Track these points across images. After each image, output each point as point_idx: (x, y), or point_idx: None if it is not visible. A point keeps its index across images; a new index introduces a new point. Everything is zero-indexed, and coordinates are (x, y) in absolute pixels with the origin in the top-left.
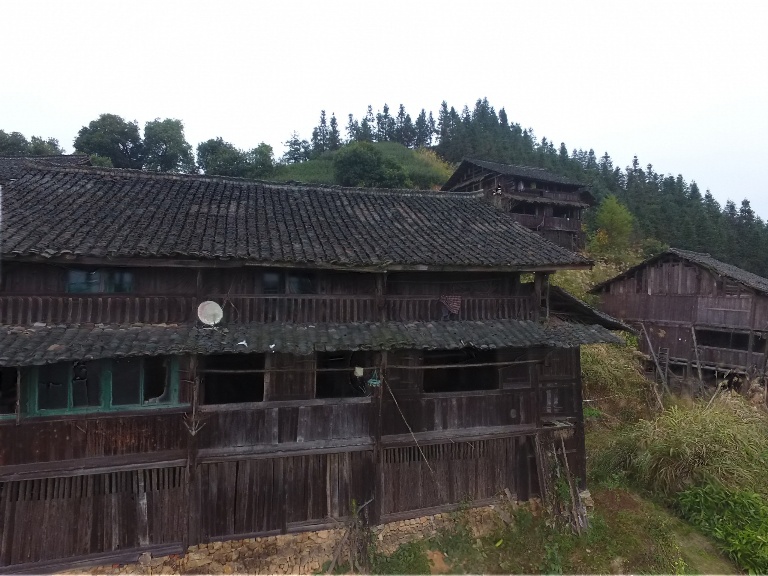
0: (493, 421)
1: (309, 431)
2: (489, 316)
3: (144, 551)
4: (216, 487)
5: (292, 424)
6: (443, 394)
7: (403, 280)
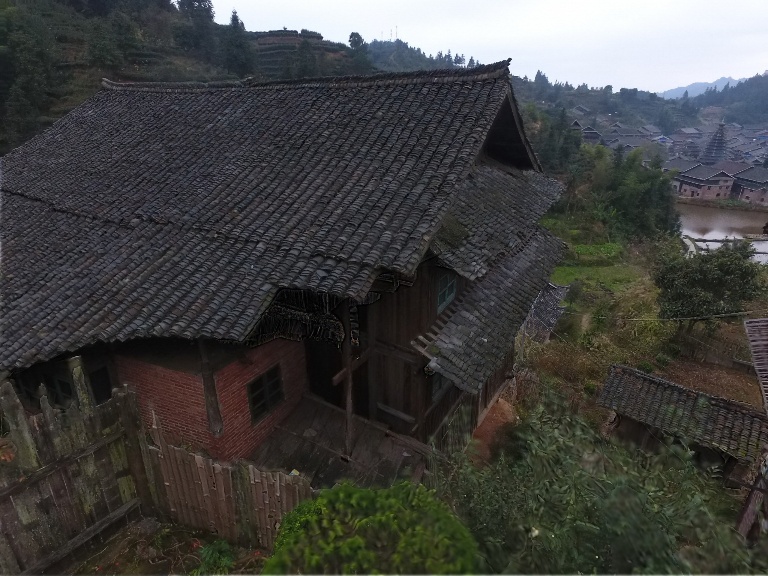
0: None
1: None
2: None
3: None
4: None
5: None
6: None
7: None
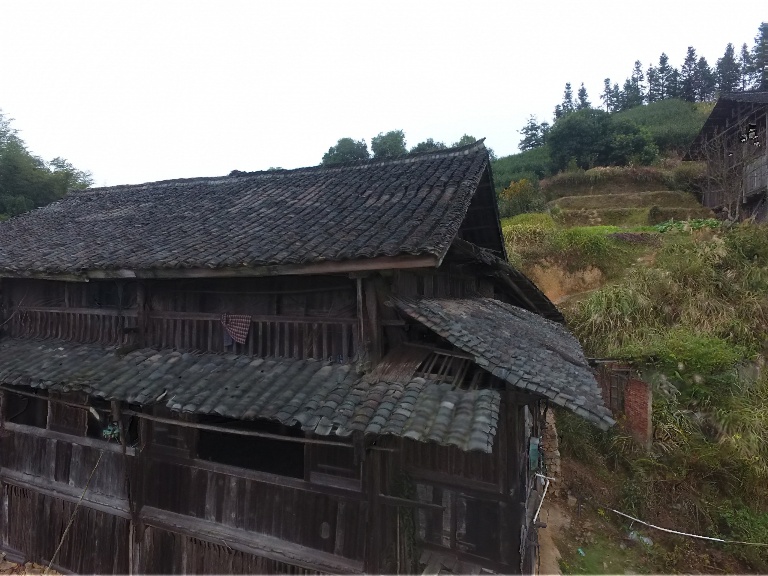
0: (289, 533)
1: (79, 475)
2: (296, 351)
3: (3, 551)
4: (50, 509)
5: (66, 462)
6: (219, 467)
7: (209, 290)
